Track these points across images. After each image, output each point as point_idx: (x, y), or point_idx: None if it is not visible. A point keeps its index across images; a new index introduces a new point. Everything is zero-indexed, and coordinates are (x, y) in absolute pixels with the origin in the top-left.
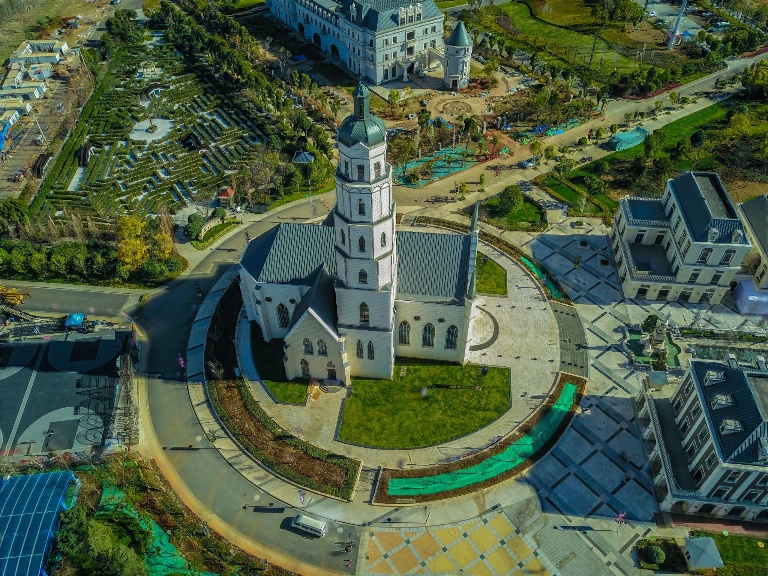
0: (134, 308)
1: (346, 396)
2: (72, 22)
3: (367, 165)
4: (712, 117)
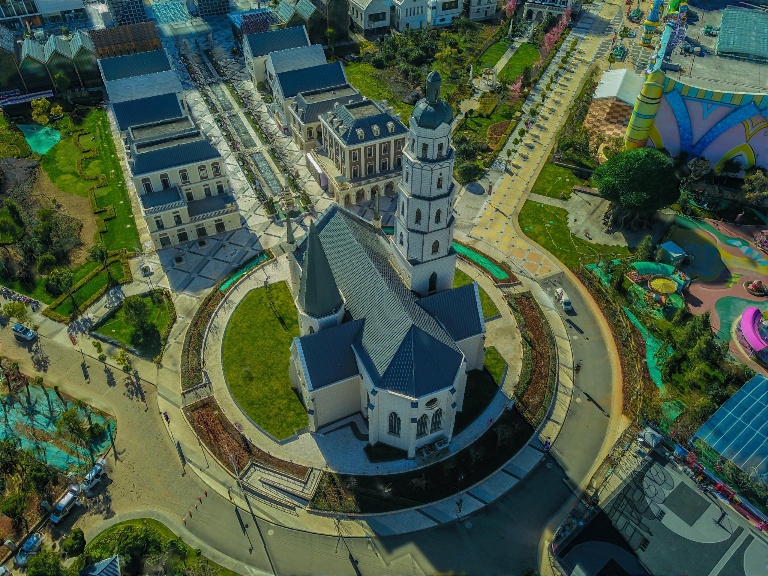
0: None
1: None
2: None
3: None
4: None
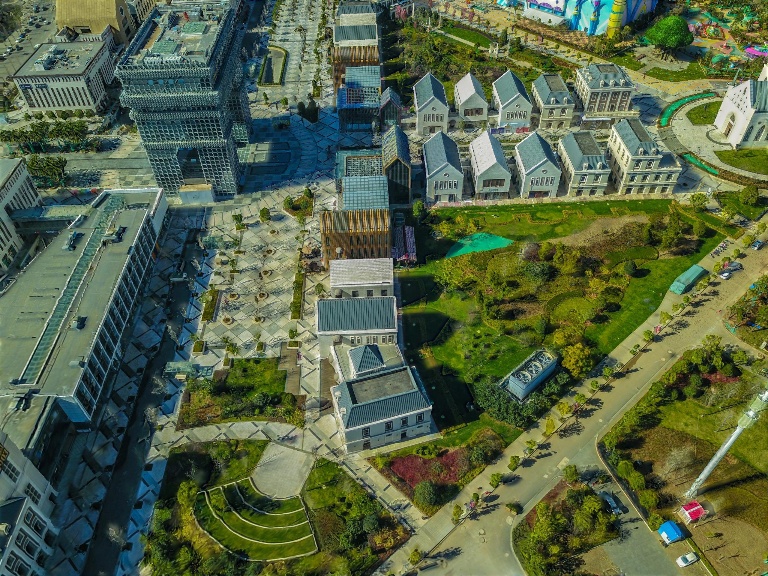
0: None
1: None
2: None
3: None
4: (613, 327)
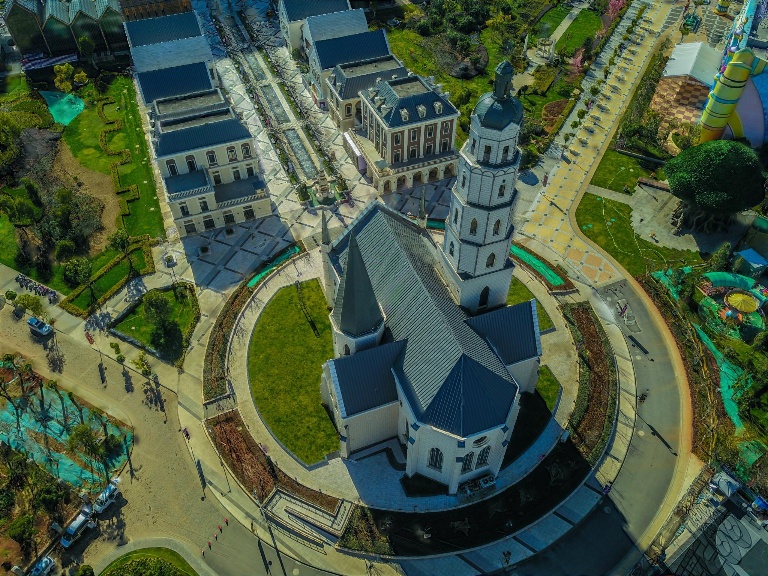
0: None
1: None
2: None
3: None
4: None
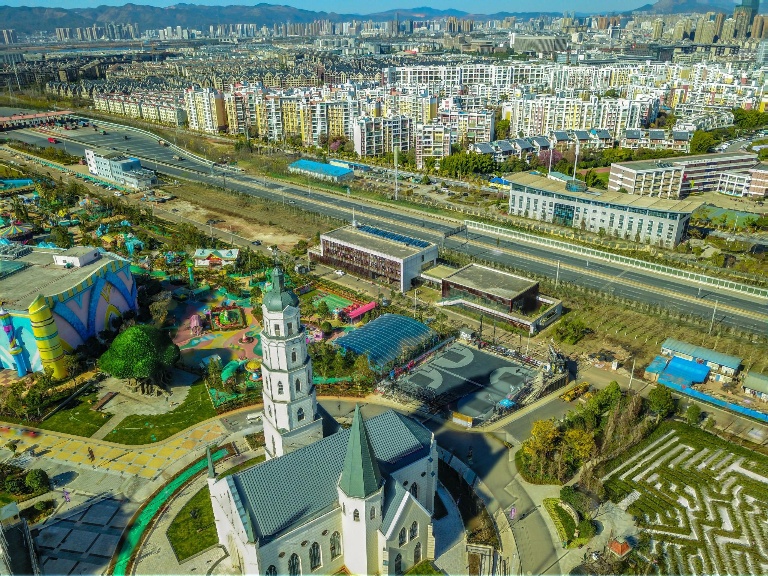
0: (502, 438)
1: None
2: None
3: None
4: None
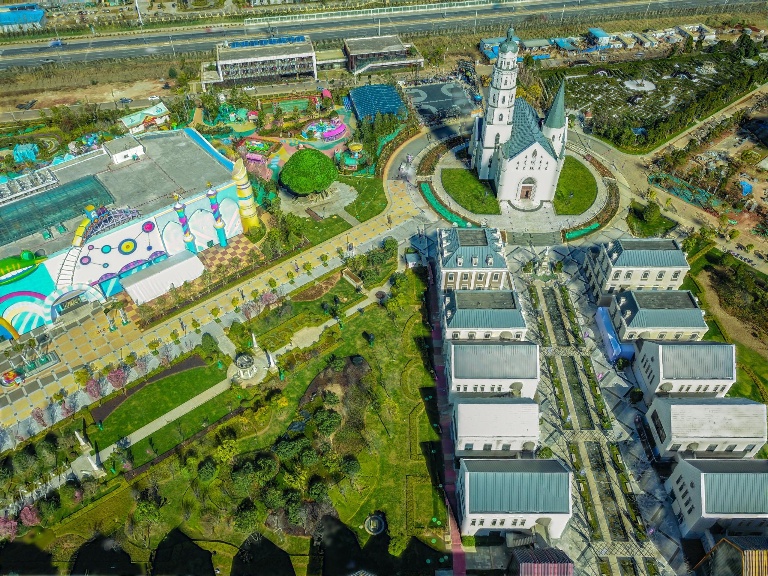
0: None
1: (465, 169)
2: (746, 30)
3: (498, 59)
4: None
